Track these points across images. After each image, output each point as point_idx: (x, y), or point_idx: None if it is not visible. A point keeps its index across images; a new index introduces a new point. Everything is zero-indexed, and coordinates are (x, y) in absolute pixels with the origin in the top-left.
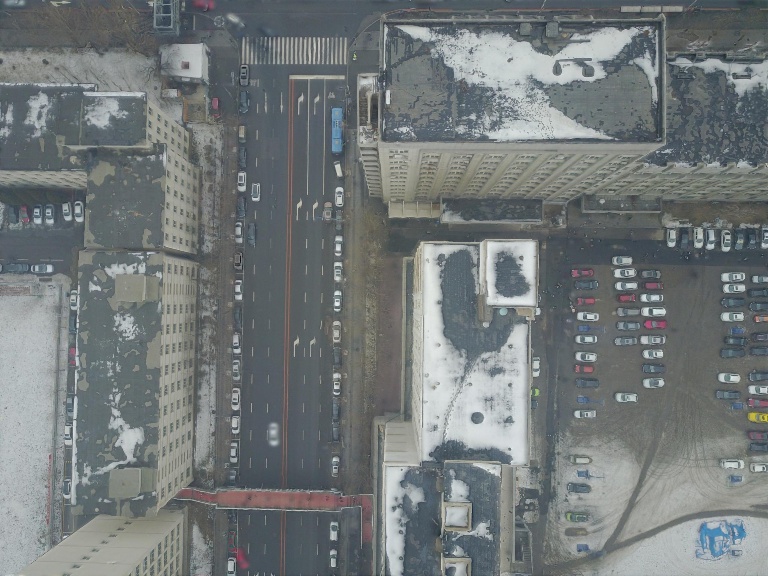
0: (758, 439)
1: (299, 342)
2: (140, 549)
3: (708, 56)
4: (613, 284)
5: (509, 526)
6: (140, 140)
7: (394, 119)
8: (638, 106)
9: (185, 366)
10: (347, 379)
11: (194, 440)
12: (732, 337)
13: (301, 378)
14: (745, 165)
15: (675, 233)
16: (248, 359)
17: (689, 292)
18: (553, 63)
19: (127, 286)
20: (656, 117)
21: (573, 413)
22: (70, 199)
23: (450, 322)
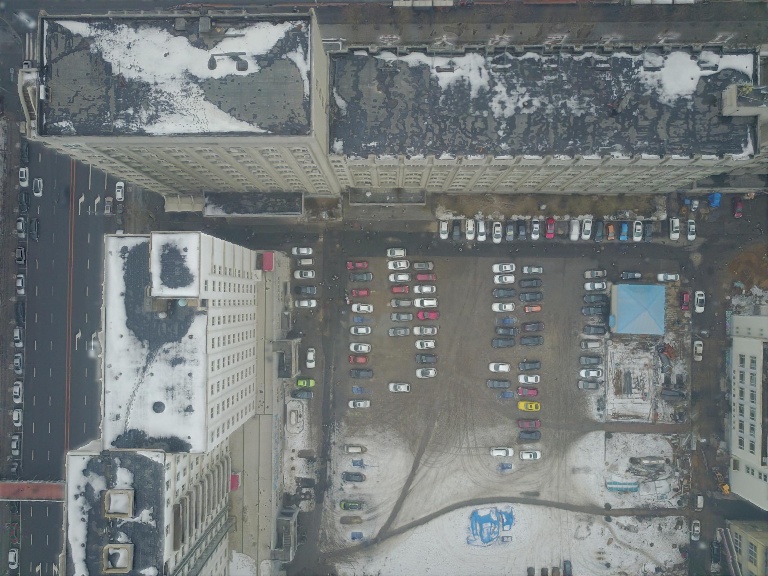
0: (527, 427)
1: (81, 335)
2: None
3: (412, 50)
4: (387, 276)
5: (269, 514)
6: None
7: (54, 113)
8: (290, 99)
9: None
10: None
11: None
12: (502, 327)
13: (83, 371)
14: (448, 157)
15: (447, 225)
16: (31, 353)
17: (462, 283)
18: (208, 57)
19: None
20: (308, 110)
21: (348, 403)
22: None
23: (133, 313)
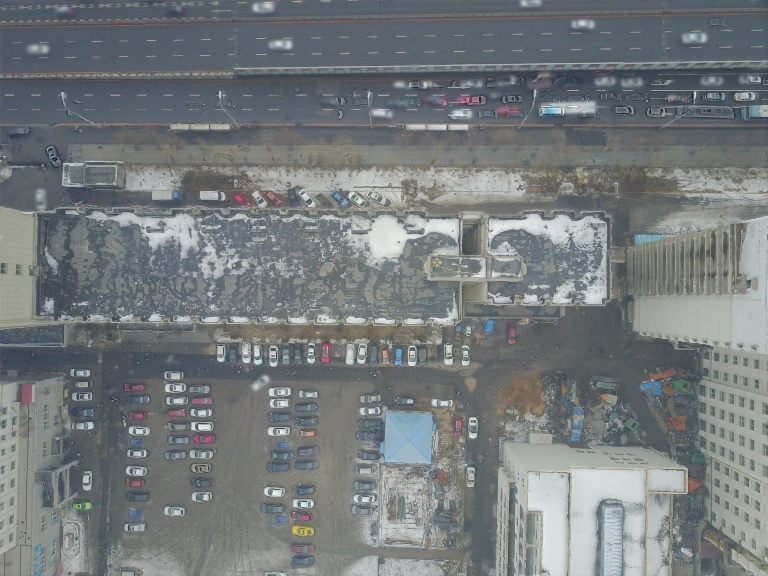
0: (300, 552)
1: None
2: None
3: (122, 210)
4: (165, 398)
5: None
6: None
7: None
8: None
9: None
10: None
11: None
12: (277, 451)
13: None
14: (157, 318)
15: (222, 349)
16: None
17: (239, 406)
18: None
19: None
20: None
21: (123, 526)
22: None
23: None
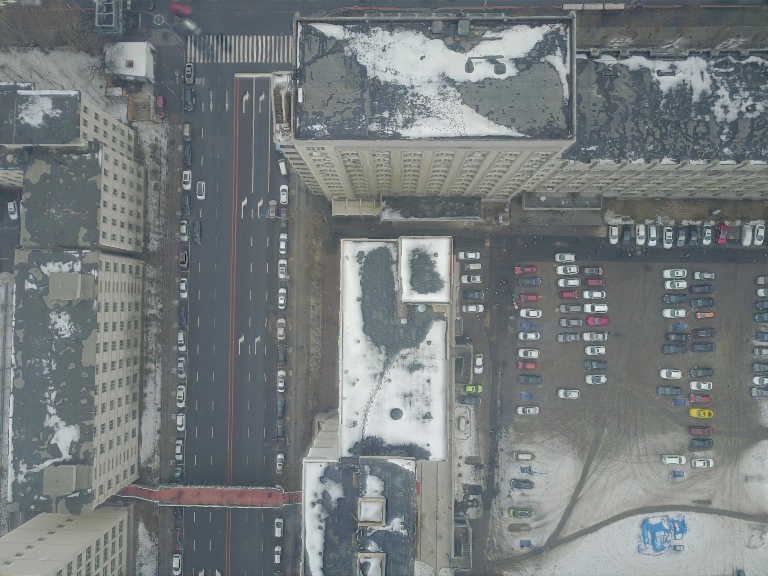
0: (699, 435)
1: (244, 340)
2: (75, 546)
3: (633, 53)
4: (556, 281)
5: (448, 522)
6: (73, 138)
7: (308, 117)
8: (549, 103)
9: (128, 364)
10: (292, 376)
11: (140, 437)
12: (674, 333)
13: (246, 375)
14: (669, 162)
15: (617, 230)
16: (193, 357)
17: (631, 289)
18: (465, 61)
19: (61, 284)
20: (567, 114)
21: (516, 409)
22: (16, 198)
23: (369, 319)
